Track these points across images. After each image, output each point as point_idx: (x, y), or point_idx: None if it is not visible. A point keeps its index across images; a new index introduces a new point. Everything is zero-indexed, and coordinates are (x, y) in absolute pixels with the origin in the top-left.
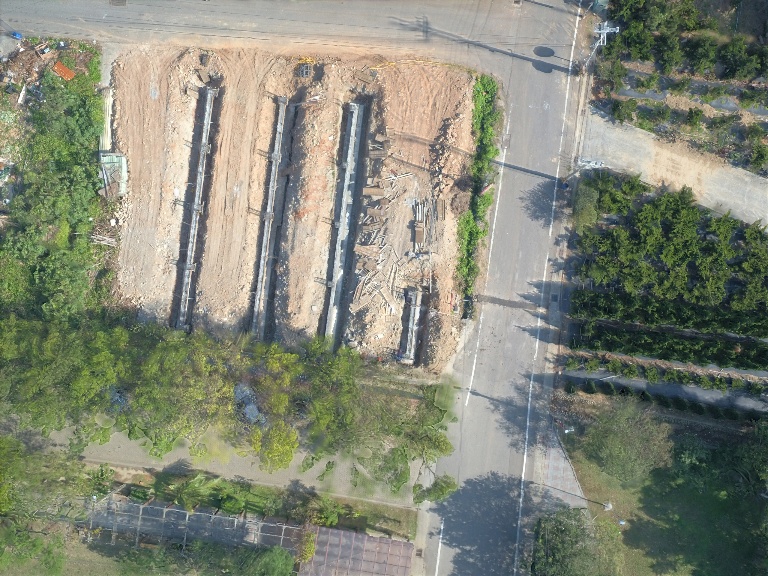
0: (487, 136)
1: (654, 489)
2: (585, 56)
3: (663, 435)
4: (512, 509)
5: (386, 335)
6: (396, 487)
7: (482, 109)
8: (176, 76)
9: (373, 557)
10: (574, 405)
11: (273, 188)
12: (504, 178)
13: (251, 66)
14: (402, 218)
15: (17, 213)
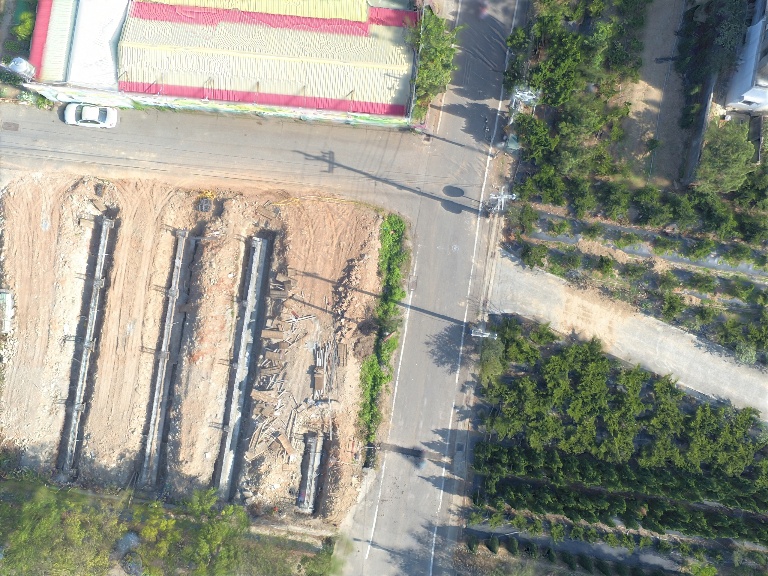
0: (393, 278)
1: None
2: None
3: None
4: None
5: (283, 484)
6: None
7: (389, 248)
8: (69, 206)
9: None
10: (479, 558)
11: (169, 326)
12: (410, 321)
13: (148, 198)
14: (302, 363)
15: None
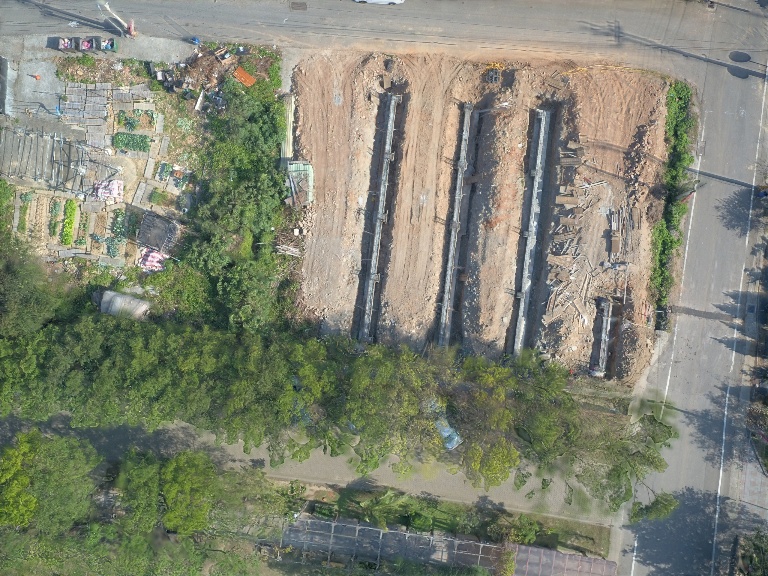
0: (682, 143)
1: None
2: None
3: None
4: (708, 526)
5: (579, 347)
6: (617, 505)
7: (675, 115)
8: (360, 82)
9: None
10: None
11: (459, 196)
12: (699, 186)
13: (437, 72)
14: (596, 227)
15: (203, 223)
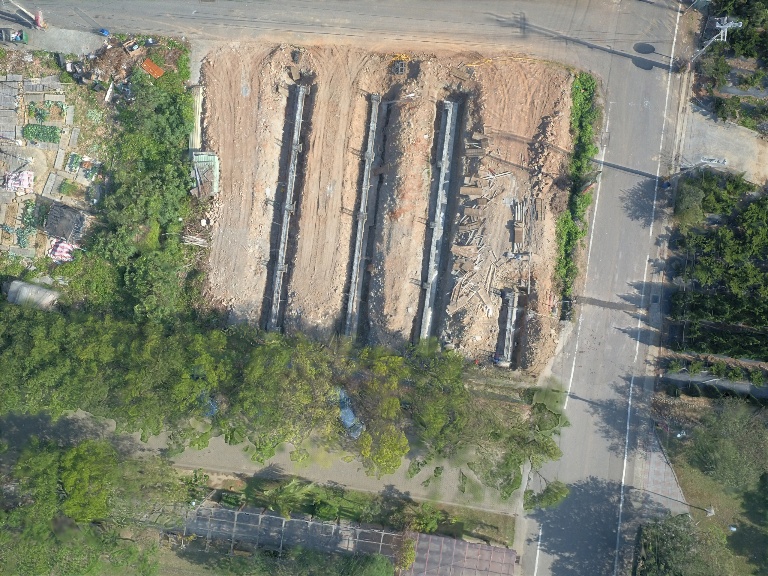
0: (586, 134)
1: (757, 494)
2: (686, 53)
3: None
4: (612, 515)
5: (483, 337)
6: (508, 493)
7: (580, 107)
8: (268, 73)
9: (475, 564)
10: (674, 408)
11: (366, 187)
12: (603, 177)
13: (344, 63)
14: (500, 218)
15: (108, 213)
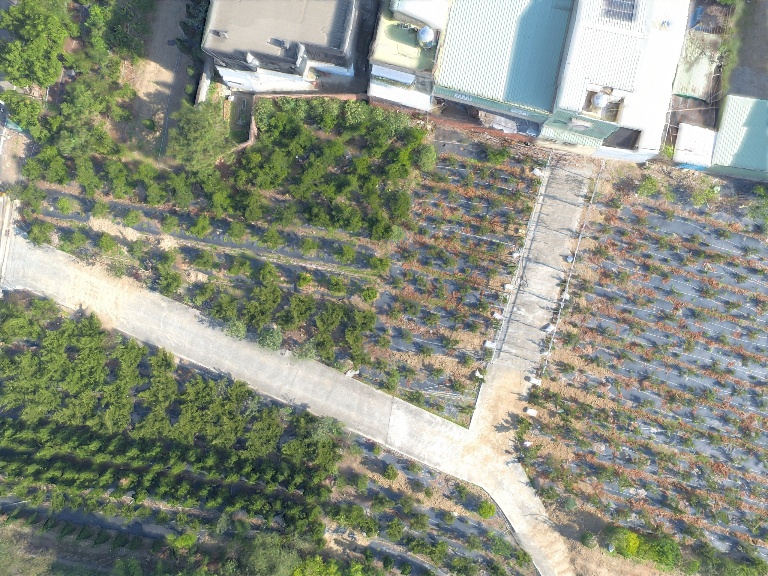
0: None
1: None
2: (10, 176)
3: (45, 567)
4: None
5: None
6: None
7: None
8: None
9: None
10: None
11: None
12: None
13: None
14: None
15: None
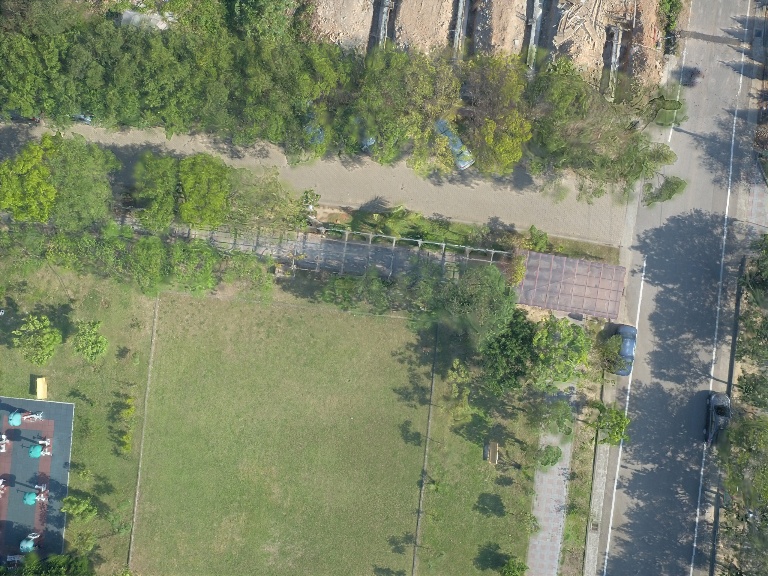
0: None
1: None
2: None
3: None
4: (716, 246)
5: (589, 69)
6: (627, 184)
7: None
8: None
9: (585, 281)
10: None
11: None
12: None
13: None
14: None
15: None
